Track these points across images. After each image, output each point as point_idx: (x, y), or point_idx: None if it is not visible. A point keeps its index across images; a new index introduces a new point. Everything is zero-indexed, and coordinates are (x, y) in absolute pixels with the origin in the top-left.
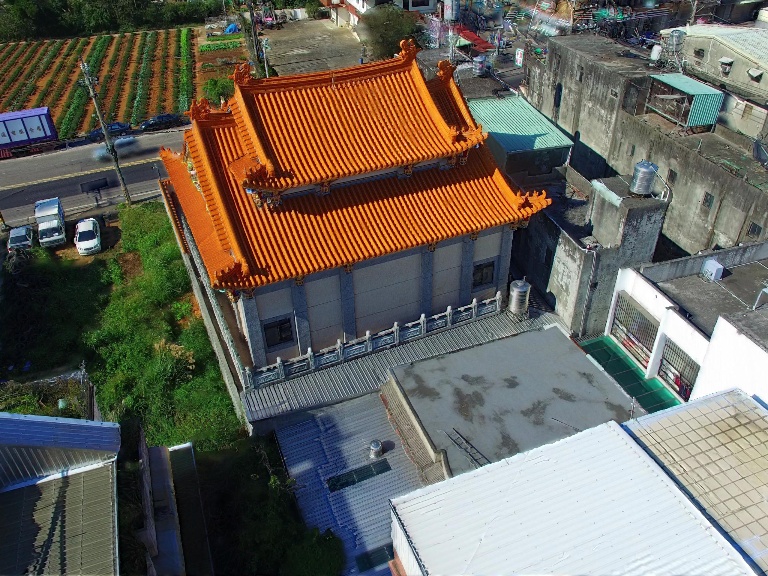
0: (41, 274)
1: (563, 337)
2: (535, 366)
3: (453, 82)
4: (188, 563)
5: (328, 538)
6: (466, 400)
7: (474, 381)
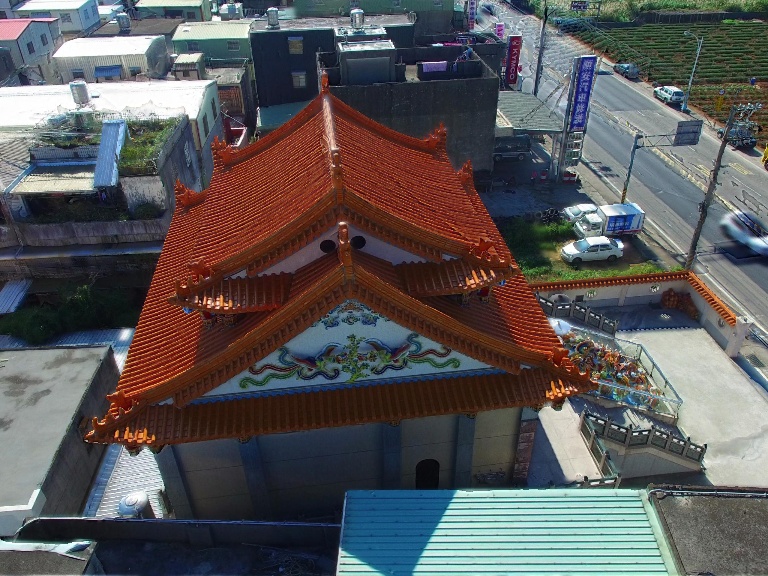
0: (512, 228)
1: (7, 503)
2: (0, 453)
3: (336, 269)
4: (99, 280)
5: (42, 326)
6: (23, 383)
7: (36, 396)
